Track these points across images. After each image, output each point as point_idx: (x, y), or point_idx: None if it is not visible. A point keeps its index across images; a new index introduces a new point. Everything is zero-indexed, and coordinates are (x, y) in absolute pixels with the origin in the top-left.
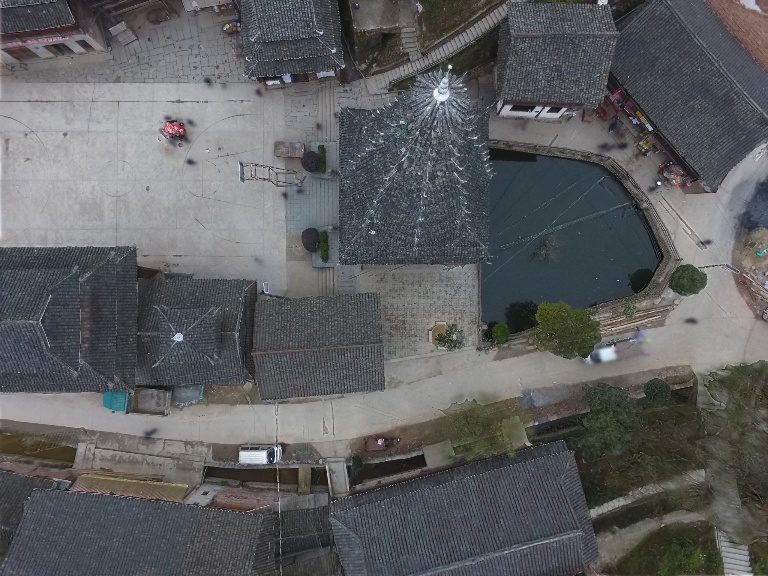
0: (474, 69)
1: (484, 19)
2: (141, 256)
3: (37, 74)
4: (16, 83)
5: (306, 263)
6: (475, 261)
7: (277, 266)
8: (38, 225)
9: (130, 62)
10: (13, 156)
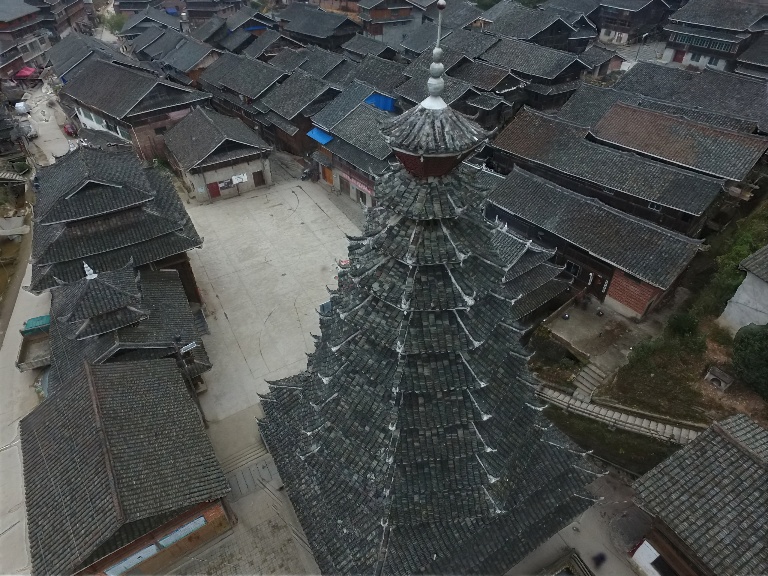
0: None
1: None
2: (216, 294)
3: (338, 200)
4: (325, 196)
5: None
6: None
7: (247, 397)
8: (220, 235)
9: None
10: (271, 210)
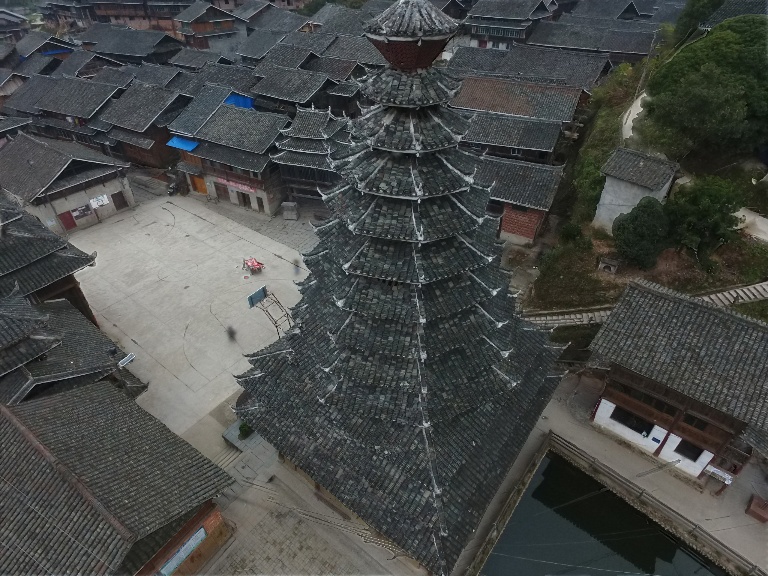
0: (580, 363)
1: (609, 311)
2: (112, 324)
3: (218, 208)
4: (202, 206)
5: (223, 430)
6: (422, 556)
7: (194, 411)
8: None
9: (277, 227)
10: (144, 230)
